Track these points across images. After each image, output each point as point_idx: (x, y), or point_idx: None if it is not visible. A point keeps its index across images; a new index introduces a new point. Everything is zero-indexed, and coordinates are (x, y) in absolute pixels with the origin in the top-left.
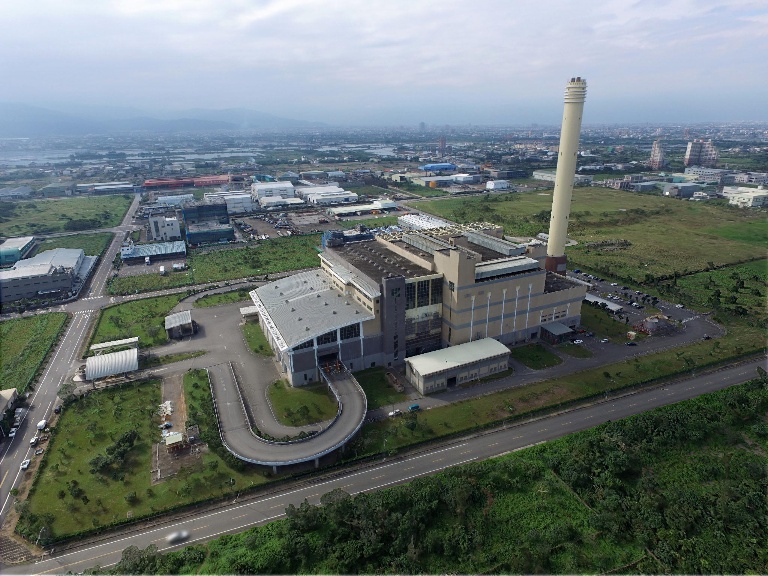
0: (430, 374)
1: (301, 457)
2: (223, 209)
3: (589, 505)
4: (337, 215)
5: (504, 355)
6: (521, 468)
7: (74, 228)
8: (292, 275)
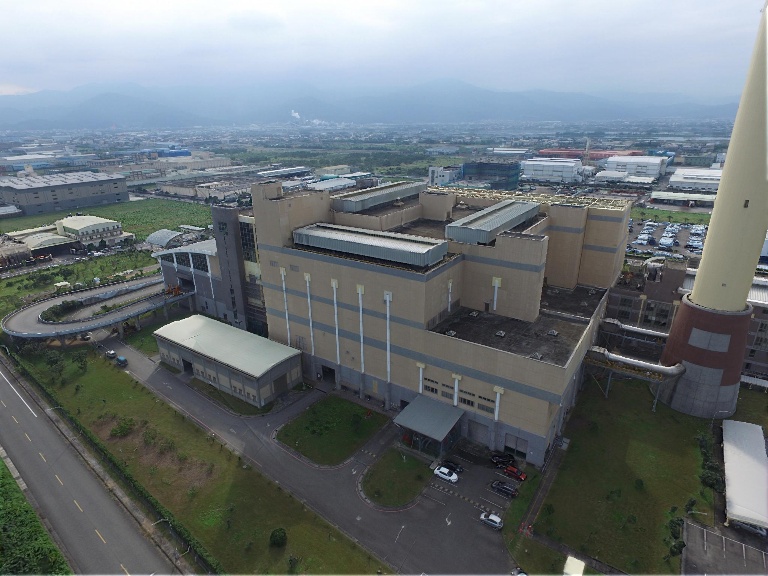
0: (159, 336)
1: (9, 326)
2: (506, 170)
3: None
4: (654, 200)
5: (246, 376)
6: None
7: (410, 173)
8: None
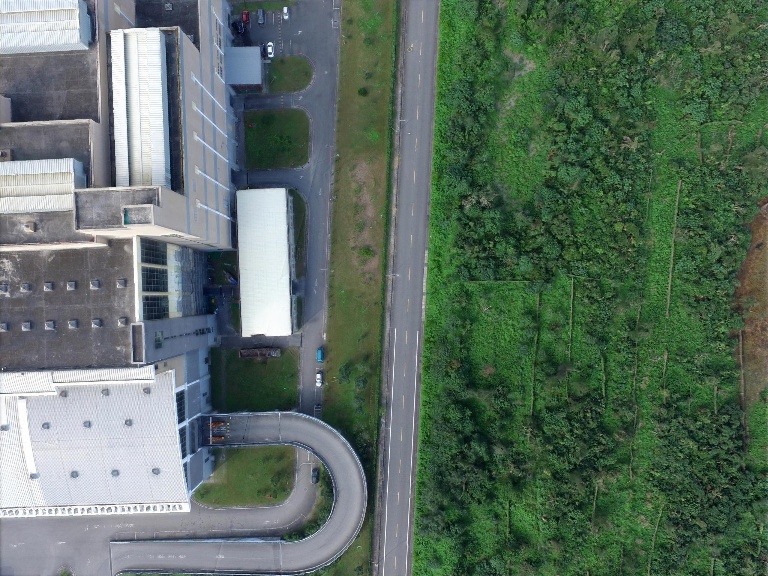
0: (292, 323)
1: (360, 506)
2: None
3: (514, 280)
4: None
5: None
6: (456, 308)
7: None
8: None
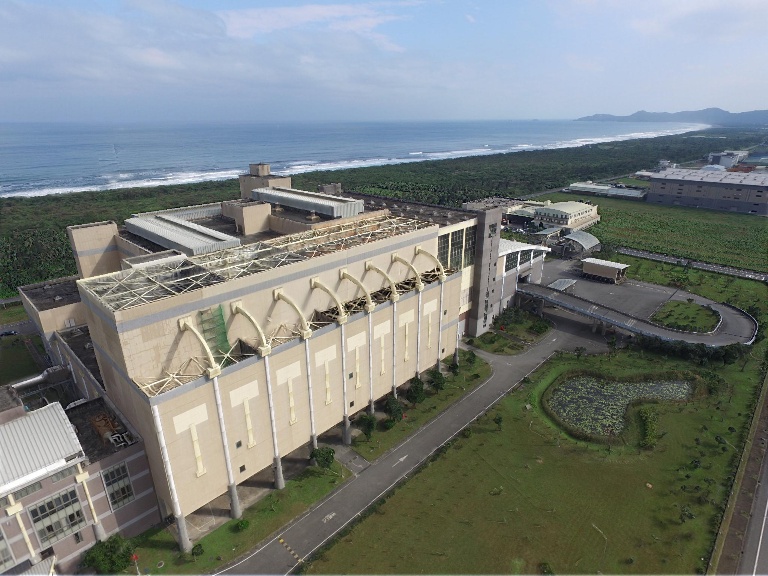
0: None
1: None
2: None
3: None
4: None
5: None
6: None
7: None
8: (524, 246)
